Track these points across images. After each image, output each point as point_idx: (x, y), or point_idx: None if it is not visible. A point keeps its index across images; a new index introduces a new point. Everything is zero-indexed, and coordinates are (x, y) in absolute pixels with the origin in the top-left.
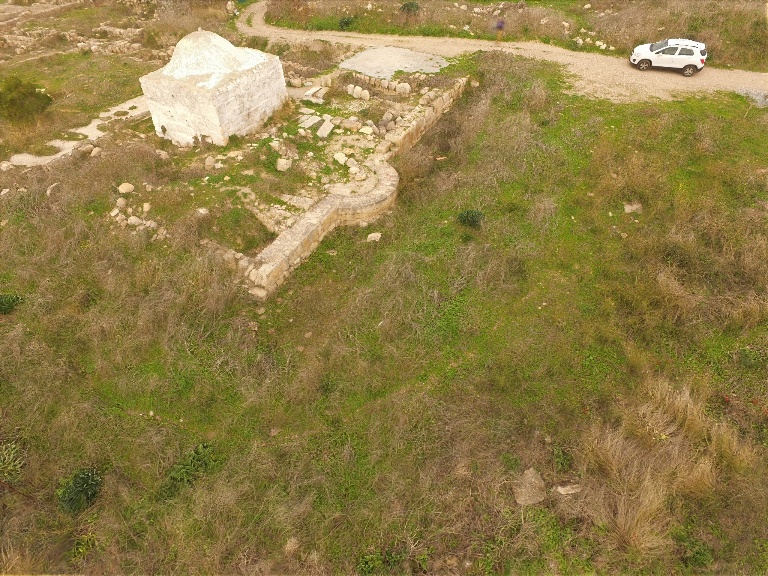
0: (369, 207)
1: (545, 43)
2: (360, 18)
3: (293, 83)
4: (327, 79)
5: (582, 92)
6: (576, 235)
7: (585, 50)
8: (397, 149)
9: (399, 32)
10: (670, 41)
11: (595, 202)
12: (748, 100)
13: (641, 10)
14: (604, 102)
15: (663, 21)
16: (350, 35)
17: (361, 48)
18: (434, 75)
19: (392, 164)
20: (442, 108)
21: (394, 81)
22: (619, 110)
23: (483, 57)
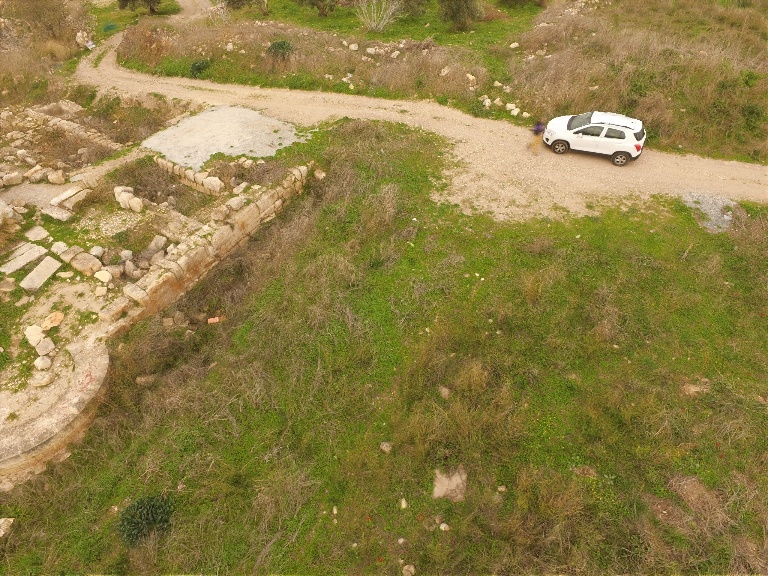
0: (12, 460)
1: (441, 104)
2: (217, 62)
3: (49, 179)
4: (87, 178)
5: (458, 197)
6: (320, 569)
7: (491, 116)
8: (138, 311)
9: (261, 82)
10: (594, 116)
11: (379, 478)
12: (697, 216)
13: (578, 54)
14: (481, 220)
15: (596, 78)
16: (200, 85)
17: (199, 108)
18: (264, 161)
19: (109, 349)
20: (259, 217)
21: (202, 172)
22: (497, 238)
23: (342, 131)
